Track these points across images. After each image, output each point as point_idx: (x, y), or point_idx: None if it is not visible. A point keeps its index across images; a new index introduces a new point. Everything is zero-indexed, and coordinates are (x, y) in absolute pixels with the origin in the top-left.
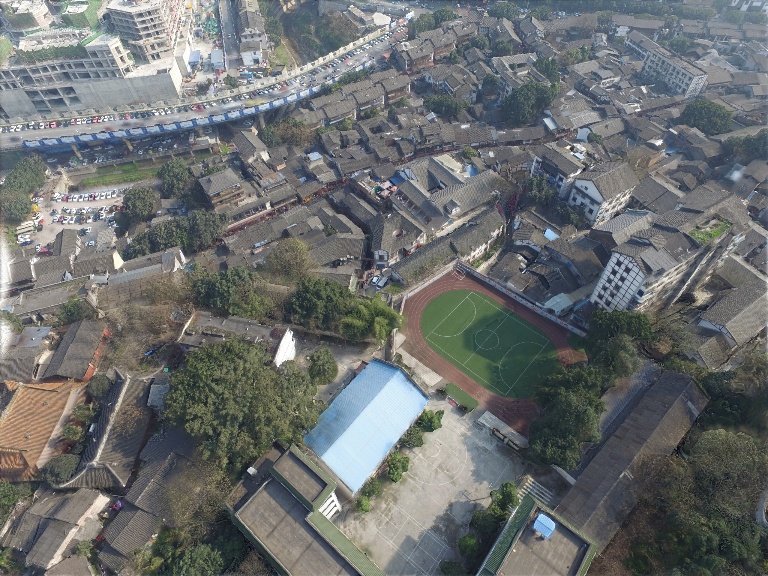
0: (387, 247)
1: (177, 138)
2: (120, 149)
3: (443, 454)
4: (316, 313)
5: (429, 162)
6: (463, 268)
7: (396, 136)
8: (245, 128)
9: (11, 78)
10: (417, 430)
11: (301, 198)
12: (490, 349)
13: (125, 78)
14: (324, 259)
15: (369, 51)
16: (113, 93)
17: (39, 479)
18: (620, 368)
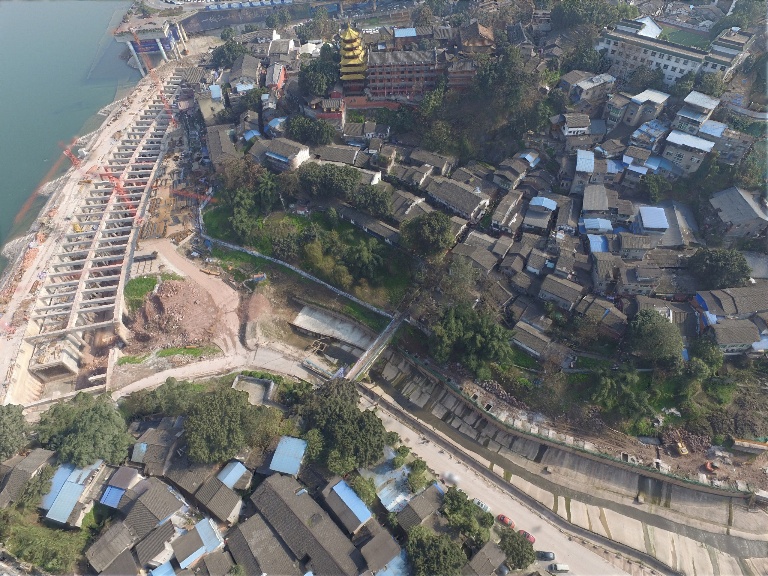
0: None
1: (402, 4)
2: (366, 10)
3: None
4: None
5: None
6: None
7: None
8: None
9: None
10: (660, 37)
11: None
12: (674, 39)
13: None
14: None
15: None
16: None
17: (495, 52)
18: (753, 15)
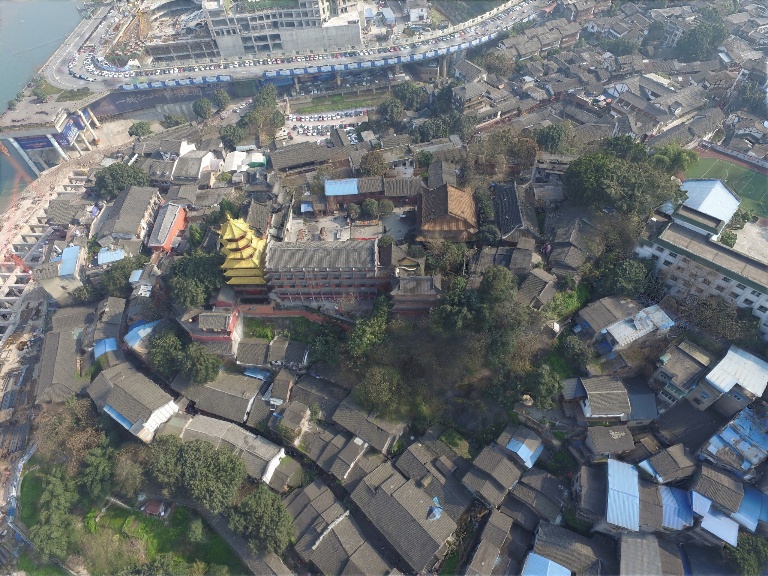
0: (636, 131)
1: (375, 76)
2: (328, 84)
3: (749, 242)
4: (629, 154)
5: (640, 79)
6: (708, 143)
7: (591, 66)
8: (432, 68)
9: (234, 25)
10: (739, 218)
11: (521, 111)
12: (749, 193)
13: (323, 27)
14: (584, 139)
15: (527, 8)
16: (310, 41)
17: (474, 239)
18: None
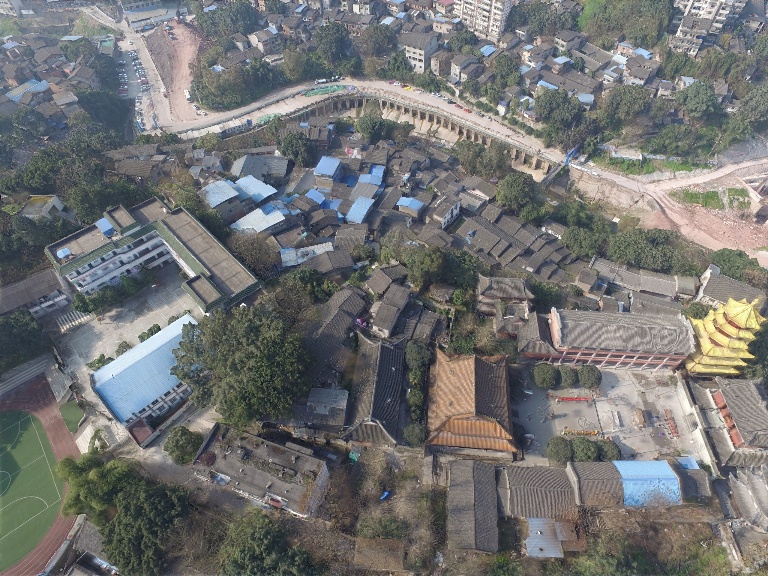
0: None
1: None
2: None
3: None
4: None
5: None
6: None
7: None
8: None
9: None
10: (118, 351)
11: None
12: (1, 471)
13: None
14: None
15: None
16: None
17: None
18: None
